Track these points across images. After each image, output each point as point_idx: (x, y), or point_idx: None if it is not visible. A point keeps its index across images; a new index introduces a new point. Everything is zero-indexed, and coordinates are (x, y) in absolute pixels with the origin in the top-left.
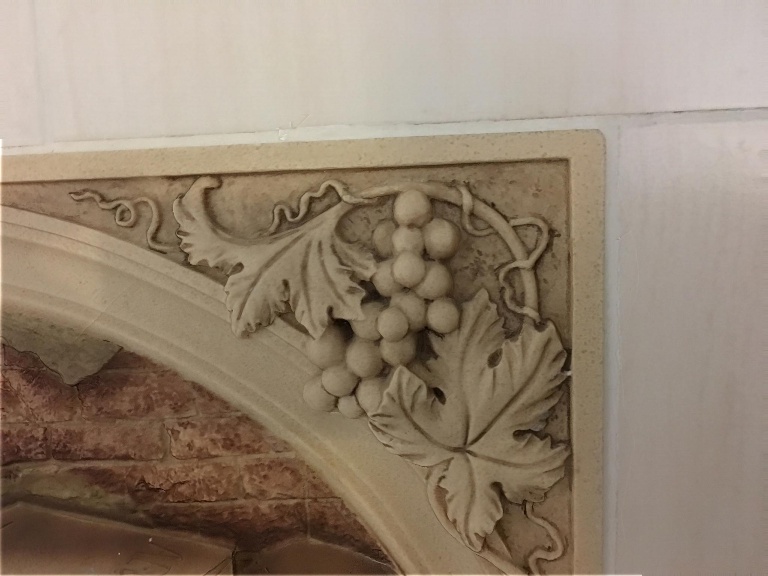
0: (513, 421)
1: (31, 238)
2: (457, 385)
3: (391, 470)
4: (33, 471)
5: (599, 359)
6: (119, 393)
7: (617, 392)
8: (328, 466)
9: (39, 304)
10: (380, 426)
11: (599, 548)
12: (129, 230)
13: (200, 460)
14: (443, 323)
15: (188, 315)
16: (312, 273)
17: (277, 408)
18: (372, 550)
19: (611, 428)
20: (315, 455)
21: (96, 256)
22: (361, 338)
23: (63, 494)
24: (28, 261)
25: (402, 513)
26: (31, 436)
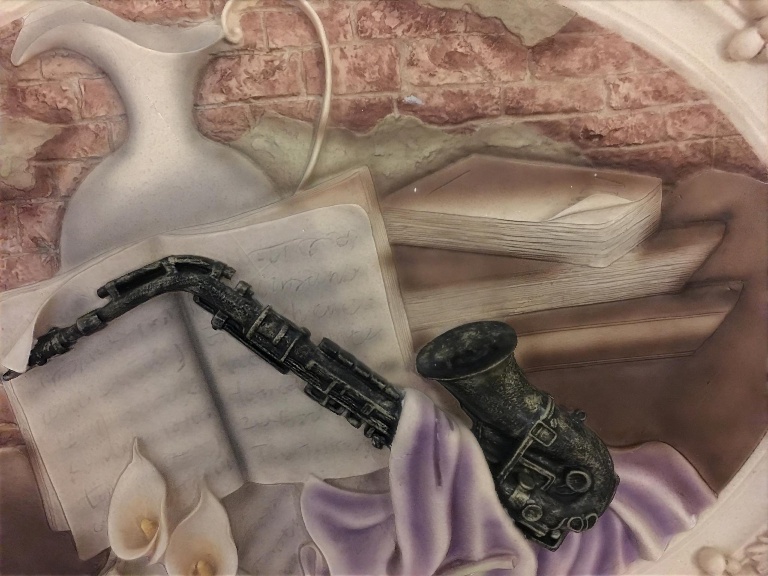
0: None
1: None
2: None
3: None
4: (491, 124)
5: None
6: (571, 53)
7: None
8: (737, 108)
9: None
10: None
11: None
12: None
13: (632, 110)
14: None
15: None
16: None
17: (700, 63)
18: (762, 174)
19: None
20: (728, 100)
21: None
22: None
23: (517, 143)
24: None
25: None
26: (488, 94)
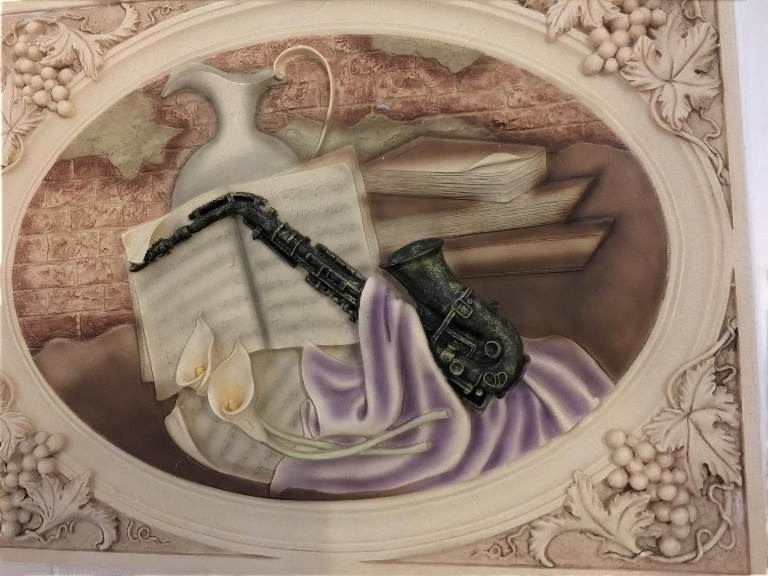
0: (694, 65)
1: (439, 0)
2: (666, 49)
3: (628, 104)
4: (431, 118)
5: (733, 36)
6: (481, 76)
7: (742, 53)
8: (595, 104)
9: (438, 35)
10: (629, 70)
11: (739, 127)
12: None
13: (524, 108)
14: (661, 17)
15: (520, 35)
16: (592, 3)
17: (567, 78)
18: (619, 145)
19: (740, 71)
20: (588, 98)
21: (475, 6)
22: (619, 28)
23: (448, 129)
24: (432, 16)
25: (634, 126)
26: (429, 102)
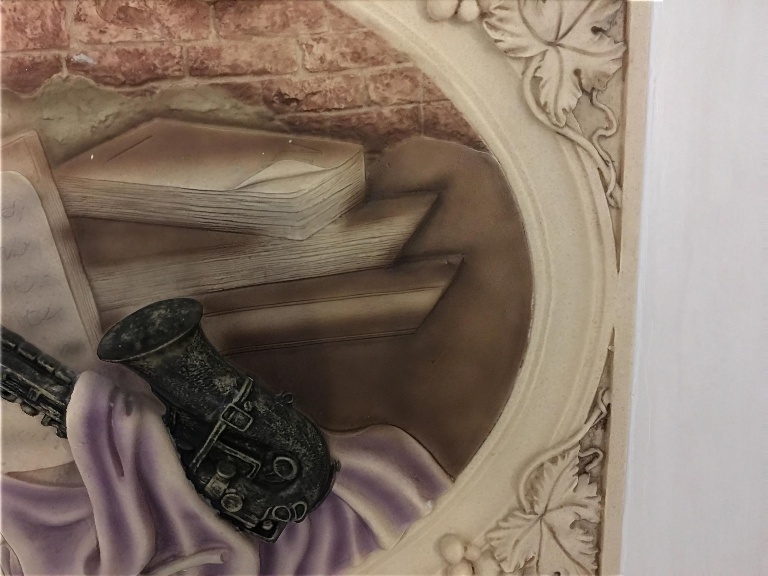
0: (592, 18)
1: None
2: None
3: (490, 74)
4: (172, 86)
5: None
6: (256, 11)
7: (659, 1)
8: (442, 72)
9: None
10: (496, 22)
11: (643, 121)
12: None
13: (330, 73)
14: None
15: None
16: None
17: (399, 23)
18: (475, 142)
19: (653, 30)
20: (431, 62)
21: None
22: None
23: (203, 107)
24: None
25: (498, 110)
26: (168, 54)
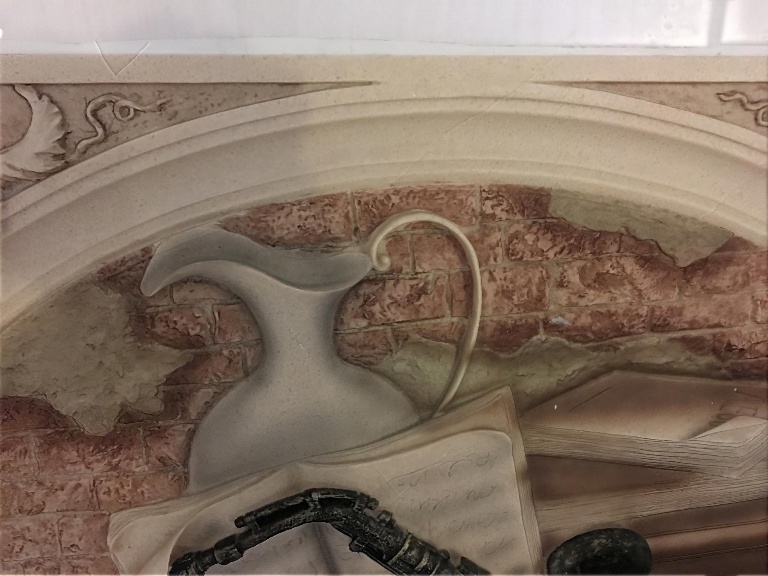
0: None
1: (681, 136)
2: None
3: None
4: (637, 343)
5: None
6: (722, 272)
7: None
8: None
9: (666, 196)
10: None
11: None
12: (766, 129)
13: None
14: None
15: None
16: None
17: None
18: None
19: None
20: None
21: (739, 153)
22: None
23: (661, 360)
24: (656, 156)
25: None
26: (636, 314)
